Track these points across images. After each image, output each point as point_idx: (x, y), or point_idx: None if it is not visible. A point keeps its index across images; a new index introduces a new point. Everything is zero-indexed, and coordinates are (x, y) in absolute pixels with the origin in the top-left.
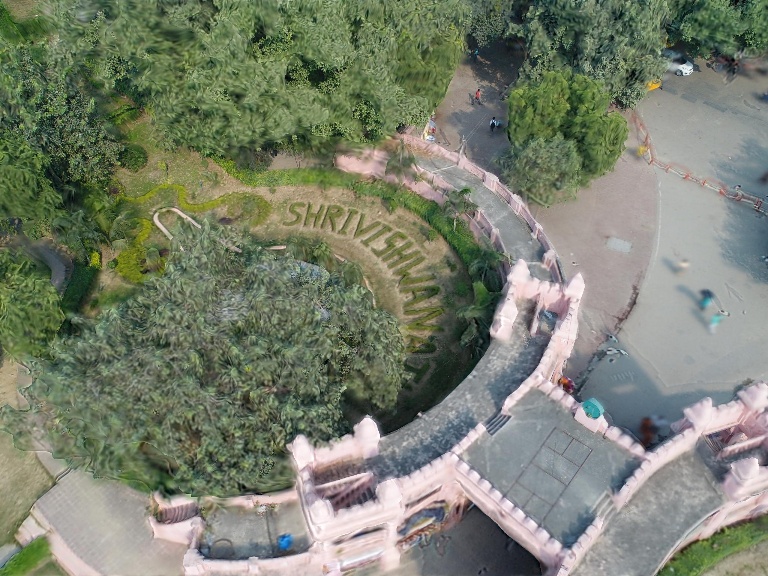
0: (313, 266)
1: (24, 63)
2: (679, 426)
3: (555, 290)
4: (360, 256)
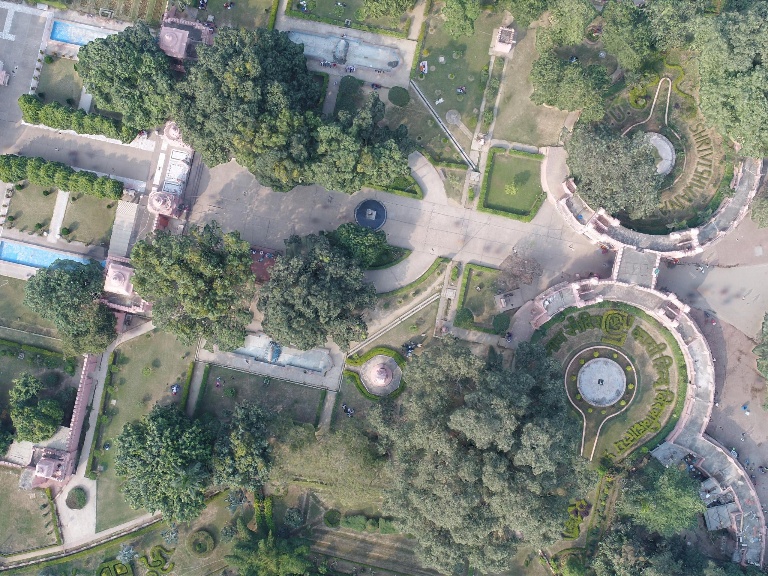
0: (675, 155)
1: (682, 7)
2: None
3: (697, 244)
4: (691, 166)
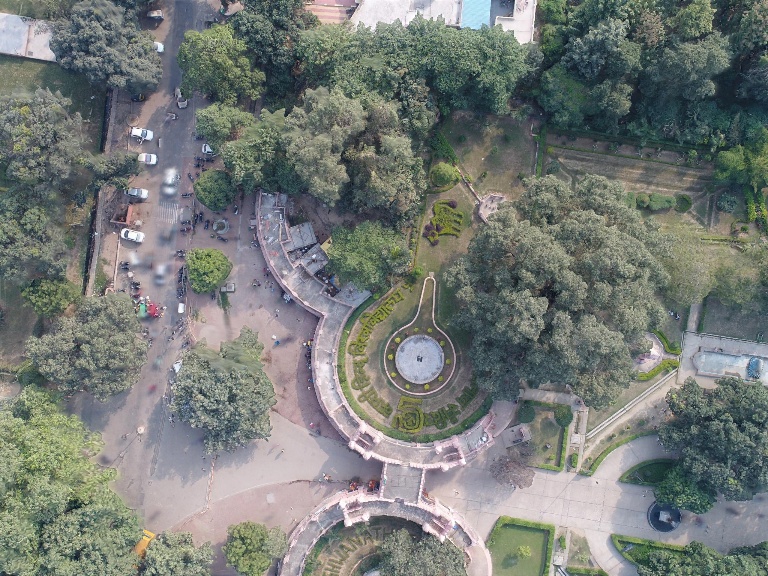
0: None
1: None
2: None
3: None
4: None
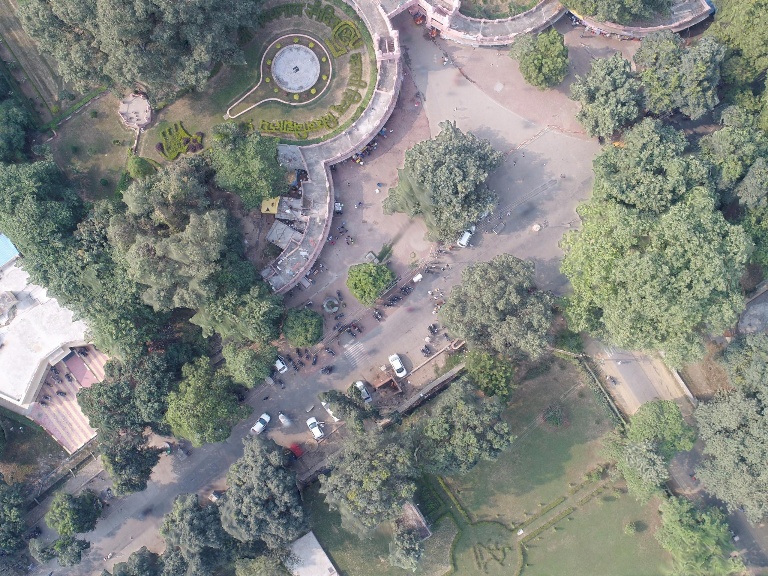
0: None
1: None
2: None
3: None
4: None
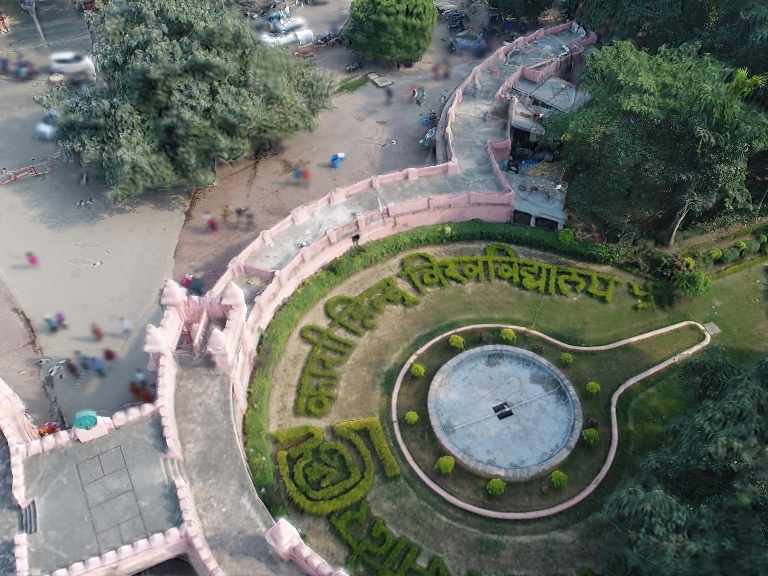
0: None
1: None
2: (154, 364)
3: None
4: None
